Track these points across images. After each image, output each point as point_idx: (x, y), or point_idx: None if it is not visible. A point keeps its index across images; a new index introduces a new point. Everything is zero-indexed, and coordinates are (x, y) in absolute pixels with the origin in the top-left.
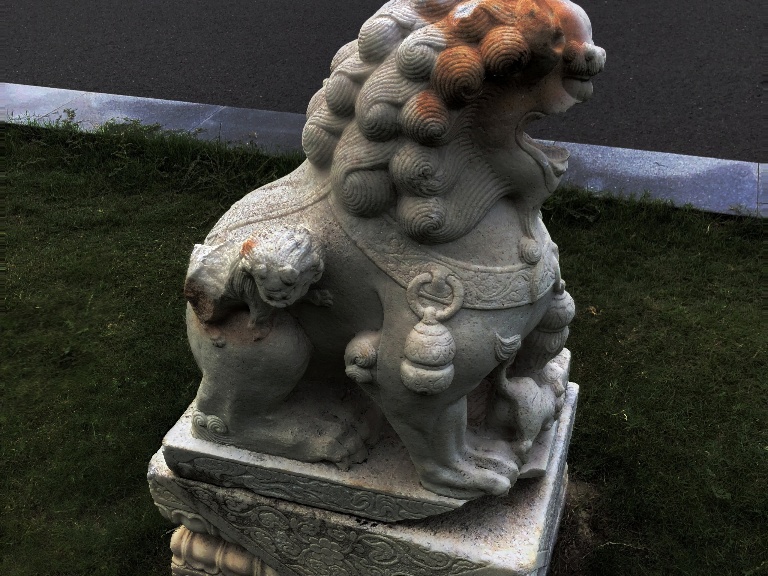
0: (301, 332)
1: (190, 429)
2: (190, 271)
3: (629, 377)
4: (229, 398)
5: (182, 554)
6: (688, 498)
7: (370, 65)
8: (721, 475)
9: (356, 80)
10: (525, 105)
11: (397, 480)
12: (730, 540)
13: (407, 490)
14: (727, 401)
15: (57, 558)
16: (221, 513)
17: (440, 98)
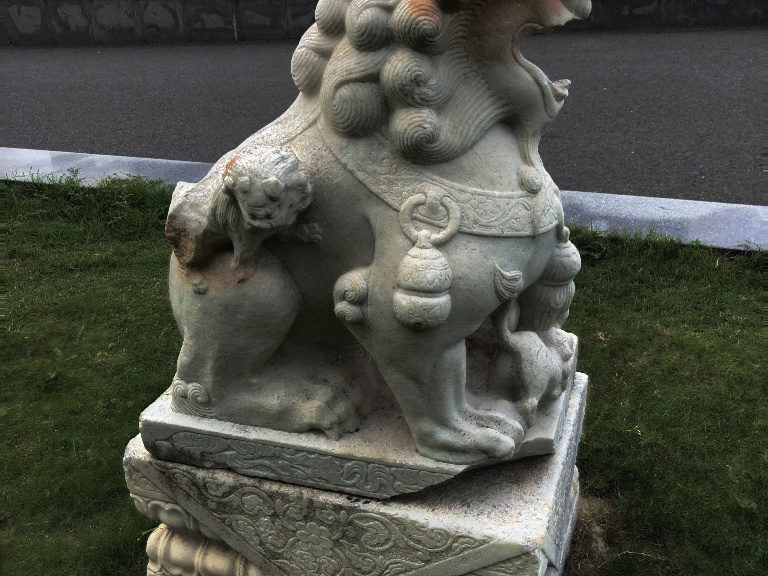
0: (288, 277)
1: (170, 404)
2: (172, 207)
3: (641, 396)
4: (211, 356)
5: (159, 557)
6: (710, 509)
7: None
8: (745, 487)
9: None
10: (521, 14)
11: (391, 448)
12: (759, 548)
13: (402, 457)
14: (747, 417)
15: (24, 568)
16: (201, 500)
17: None
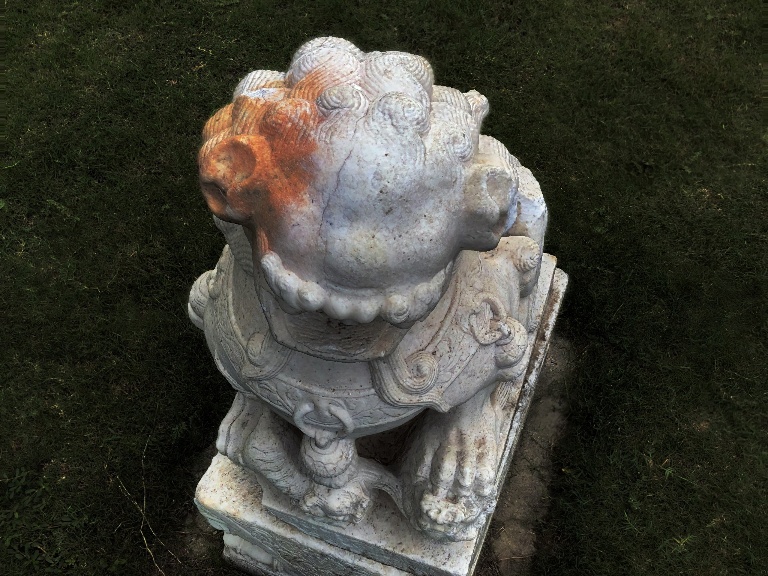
0: None
1: None
2: None
3: None
4: None
5: None
6: None
7: None
8: None
9: None
10: None
11: None
12: None
13: None
14: None
15: None
16: None
17: None
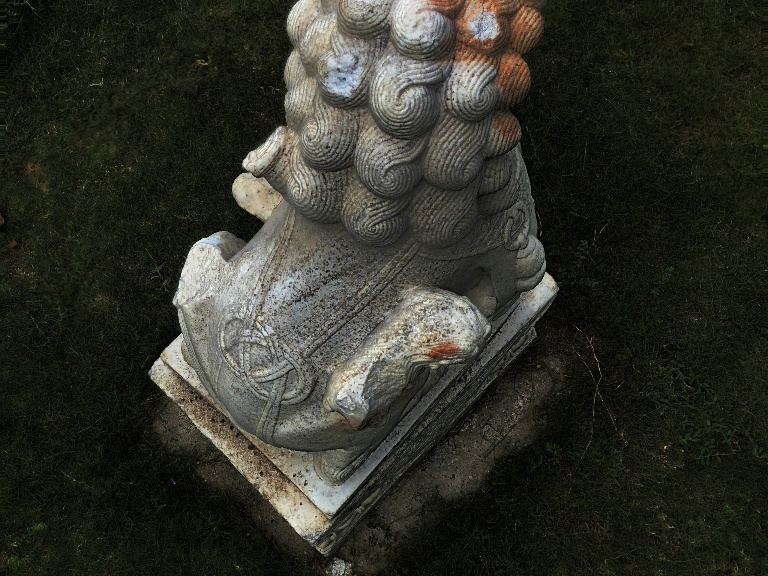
0: None
1: (328, 486)
2: (362, 415)
3: None
4: None
5: None
6: None
7: (421, 138)
8: None
9: (416, 159)
10: None
11: None
12: None
13: None
14: None
15: None
16: None
17: (507, 111)
